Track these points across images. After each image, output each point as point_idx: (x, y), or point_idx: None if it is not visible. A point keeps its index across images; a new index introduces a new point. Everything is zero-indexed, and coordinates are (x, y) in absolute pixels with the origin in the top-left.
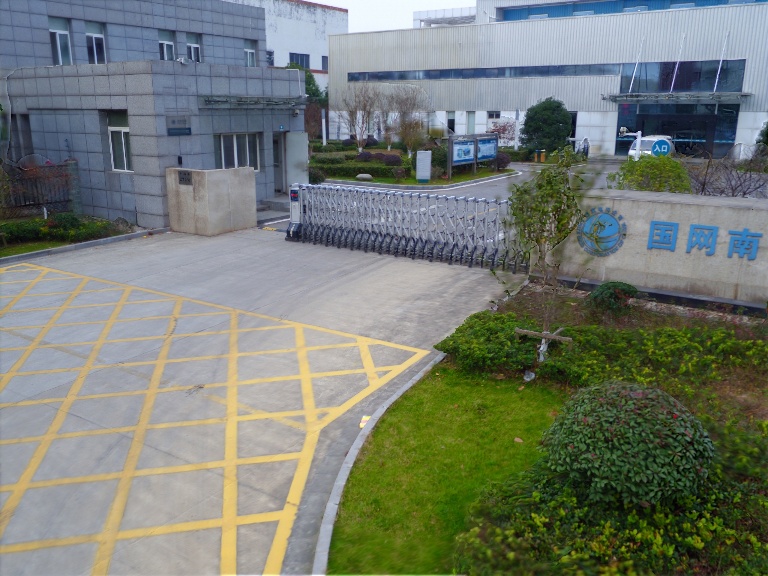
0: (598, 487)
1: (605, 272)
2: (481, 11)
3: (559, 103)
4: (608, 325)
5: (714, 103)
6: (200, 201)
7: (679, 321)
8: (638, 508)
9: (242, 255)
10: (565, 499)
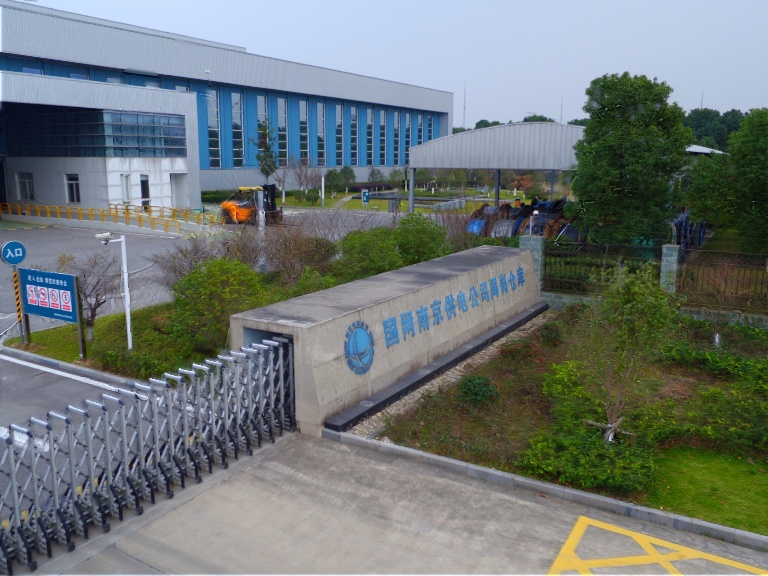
0: None
1: (371, 386)
2: None
3: None
4: None
5: None
6: None
7: None
8: None
9: None
10: None
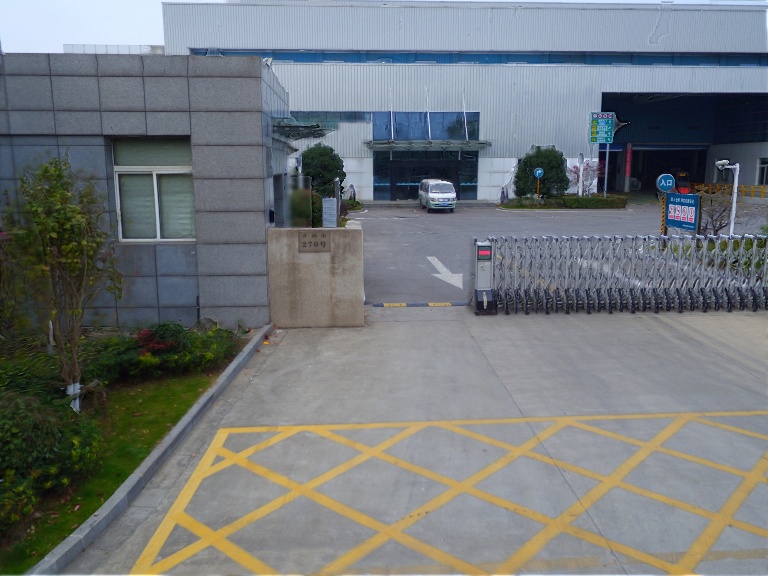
0: None
1: None
2: (214, 49)
3: (331, 149)
4: None
5: (457, 150)
6: (345, 275)
7: None
8: None
9: (507, 342)
10: None
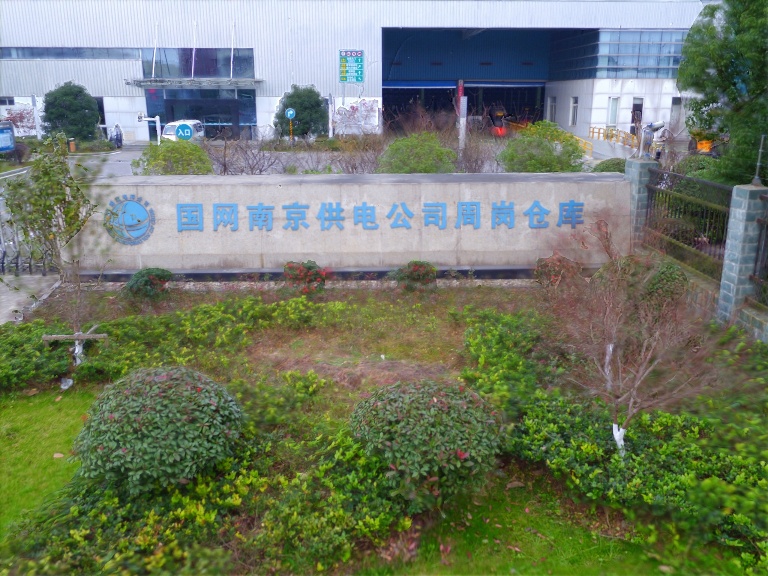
0: (134, 480)
1: (141, 260)
2: None
3: (80, 88)
4: None
5: (233, 88)
6: None
7: (215, 296)
8: (180, 487)
9: None
10: (106, 503)
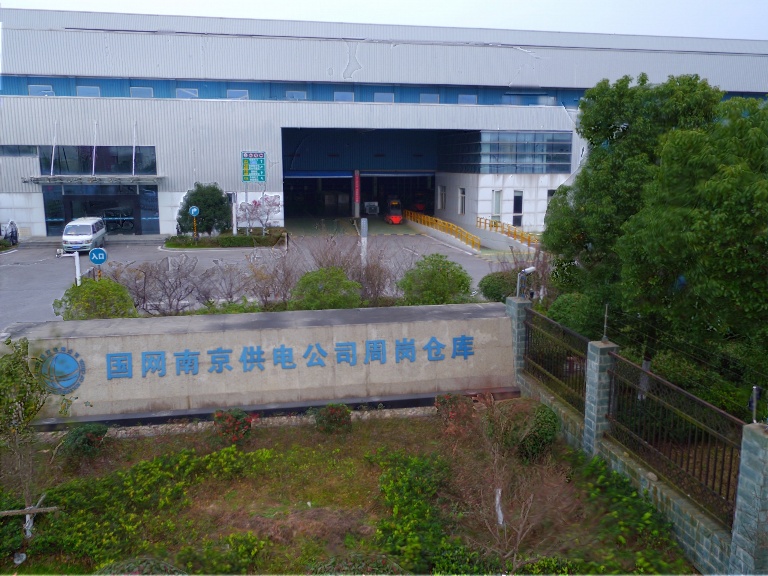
0: None
1: (71, 408)
2: None
3: None
4: (87, 472)
5: (135, 184)
6: None
7: (149, 447)
8: None
9: None
10: None
